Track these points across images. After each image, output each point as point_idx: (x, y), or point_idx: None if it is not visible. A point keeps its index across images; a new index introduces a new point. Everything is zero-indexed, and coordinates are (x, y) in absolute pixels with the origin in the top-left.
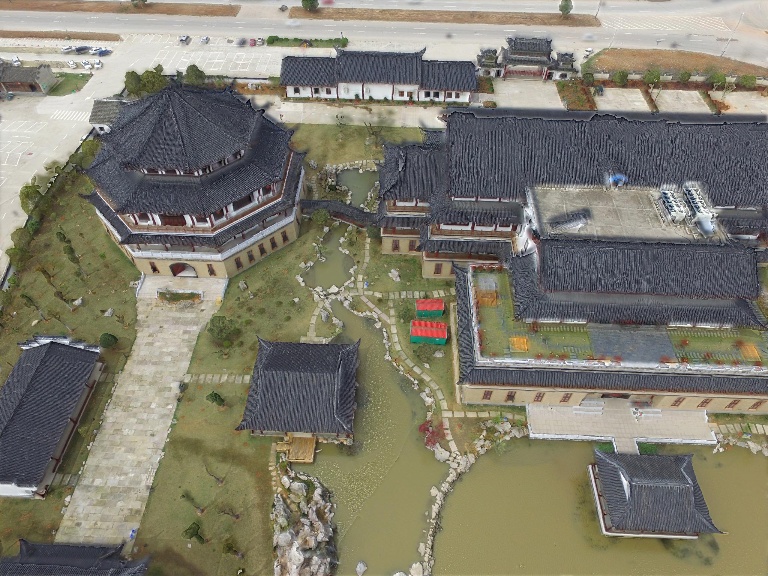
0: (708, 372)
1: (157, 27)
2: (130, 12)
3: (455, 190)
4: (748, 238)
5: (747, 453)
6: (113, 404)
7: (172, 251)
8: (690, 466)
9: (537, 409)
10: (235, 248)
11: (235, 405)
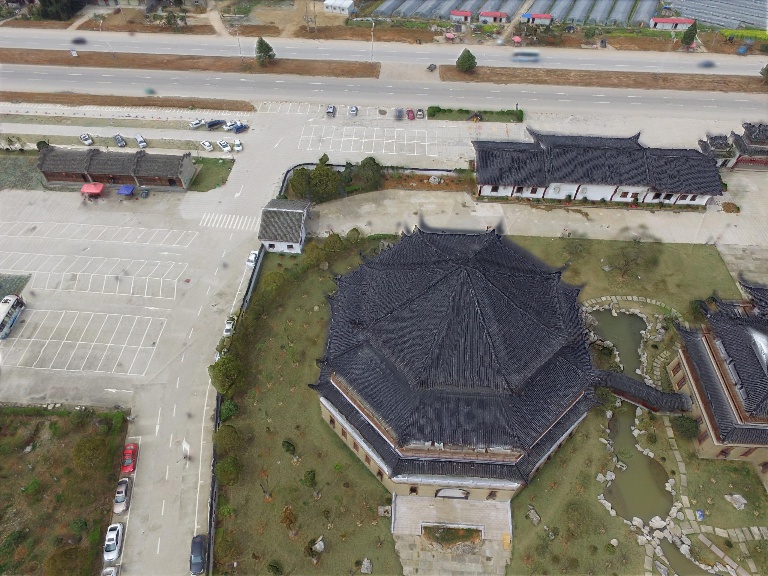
0: None
1: (291, 92)
2: (255, 71)
3: None
4: None
5: None
6: None
7: (450, 478)
8: None
9: None
10: None
11: None
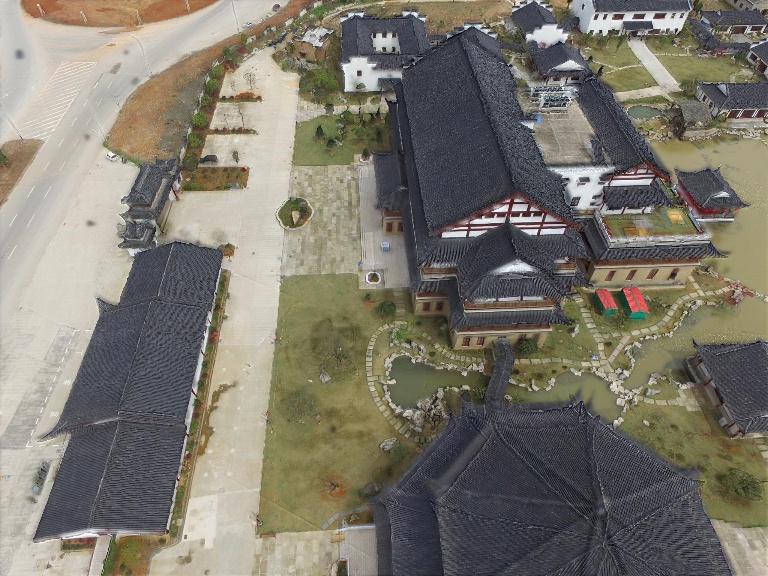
0: None
1: None
2: None
3: None
4: None
5: None
6: None
7: None
8: None
9: None
10: None
11: None
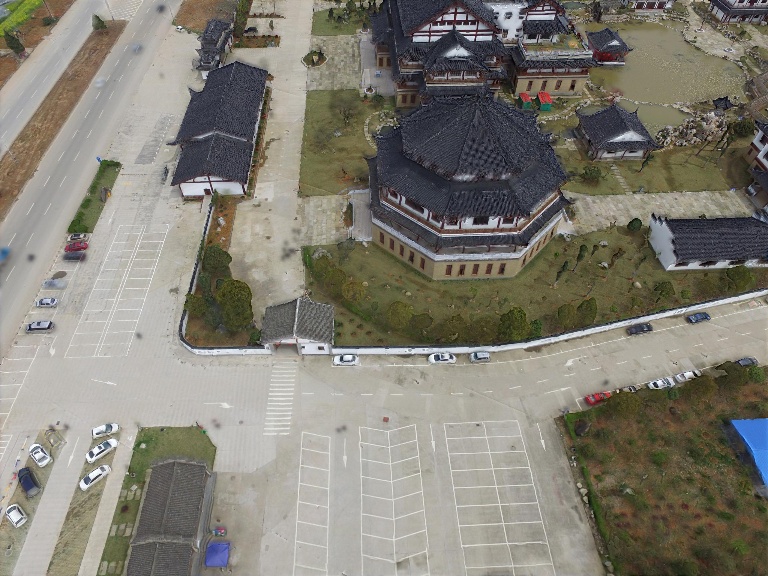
0: None
1: None
2: None
3: None
4: None
5: None
6: None
7: None
8: None
9: None
10: None
11: (635, 169)
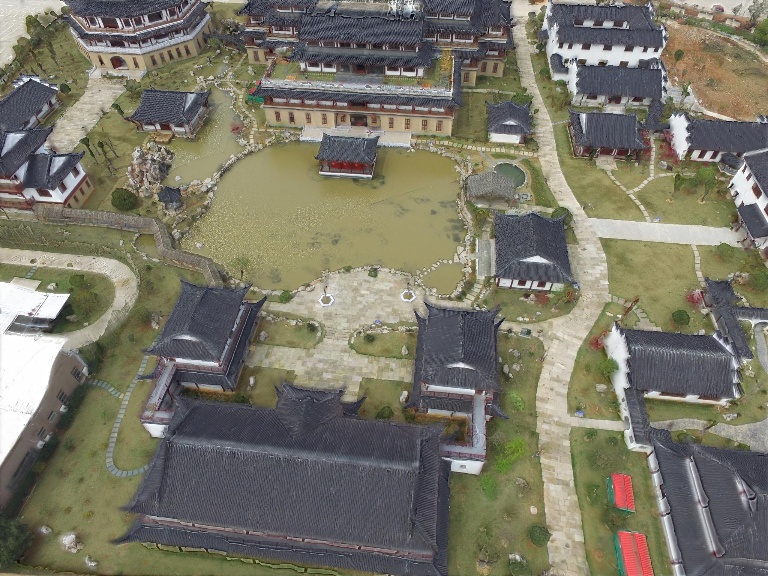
0: (394, 92)
1: None
2: None
3: (275, 2)
4: (465, 41)
5: (428, 153)
6: (63, 118)
7: None
8: (375, 141)
9: (310, 129)
10: (150, 48)
11: None
